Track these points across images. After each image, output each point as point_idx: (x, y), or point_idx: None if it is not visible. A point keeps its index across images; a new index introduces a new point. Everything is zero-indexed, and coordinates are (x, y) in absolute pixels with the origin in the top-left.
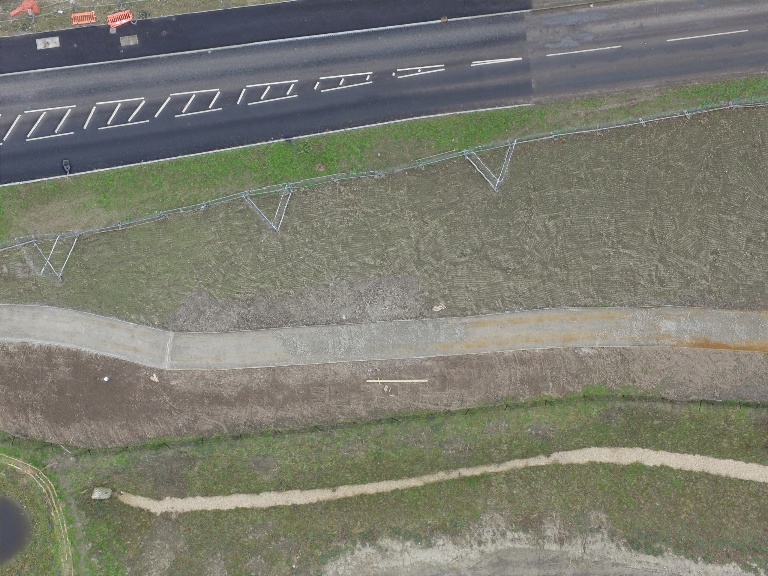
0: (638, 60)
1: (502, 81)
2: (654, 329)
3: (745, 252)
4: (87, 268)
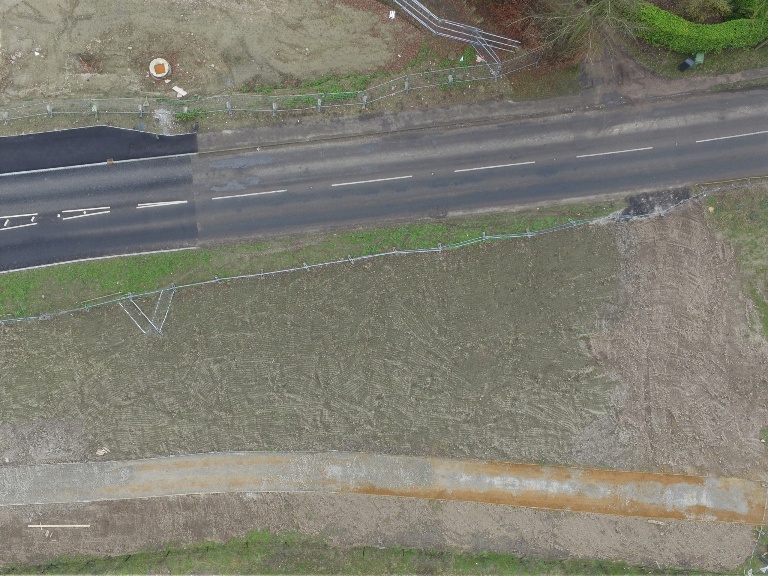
0: (303, 204)
1: (167, 224)
2: (320, 474)
3: (410, 397)
4: None
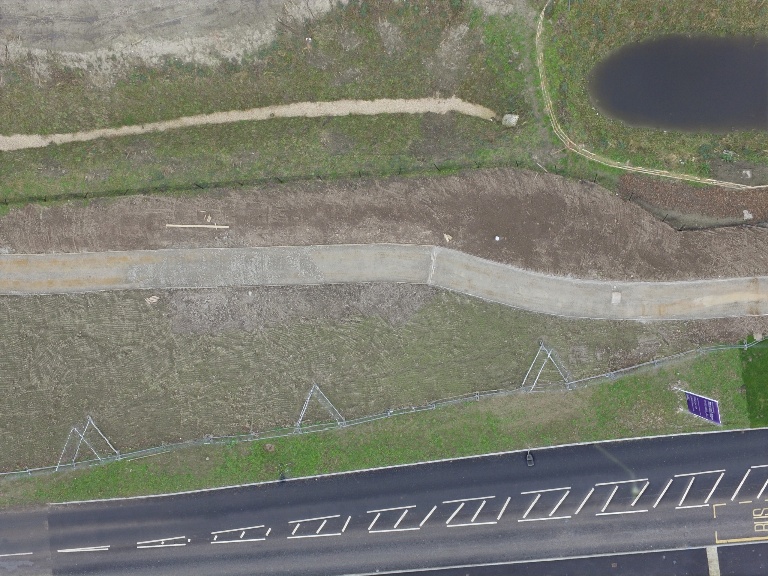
0: None
1: (79, 529)
2: None
3: None
4: (514, 353)
